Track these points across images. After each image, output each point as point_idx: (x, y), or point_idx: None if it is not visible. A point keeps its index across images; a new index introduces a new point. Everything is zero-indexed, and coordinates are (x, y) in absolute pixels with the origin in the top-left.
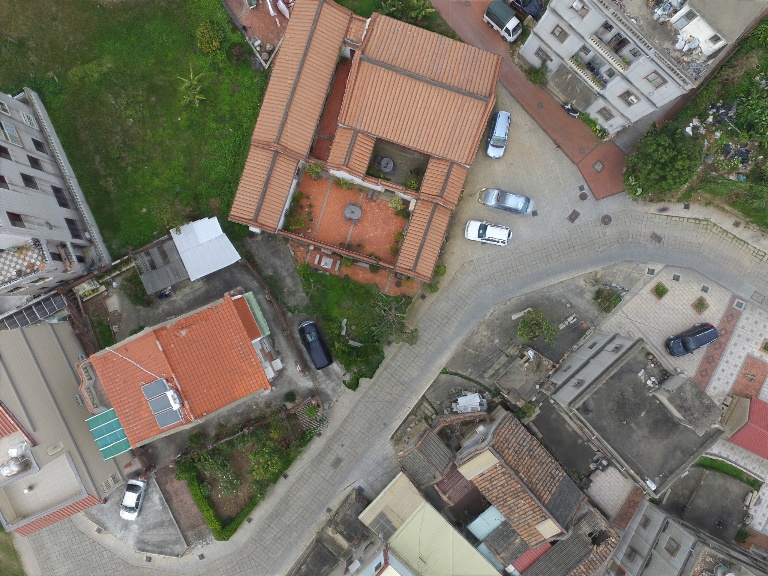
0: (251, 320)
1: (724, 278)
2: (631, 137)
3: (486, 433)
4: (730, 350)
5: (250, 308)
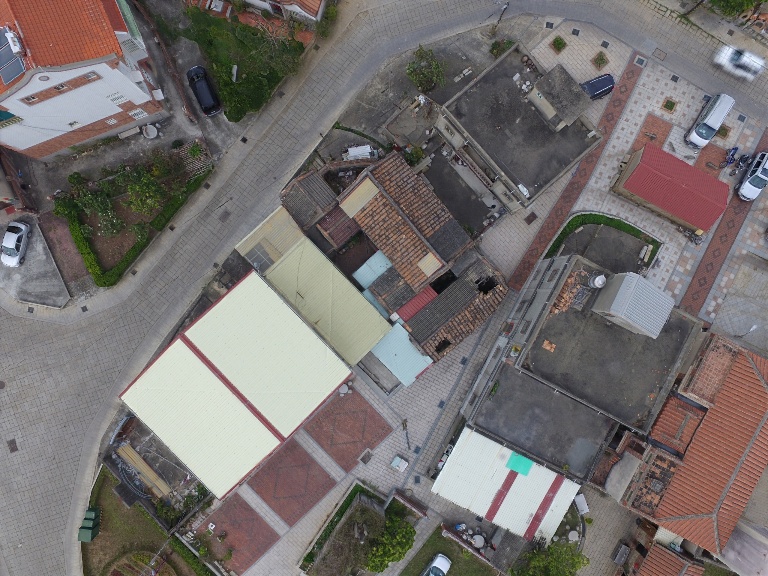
0: (117, 14)
1: (625, 34)
2: None
3: None
4: (630, 108)
5: (119, 8)
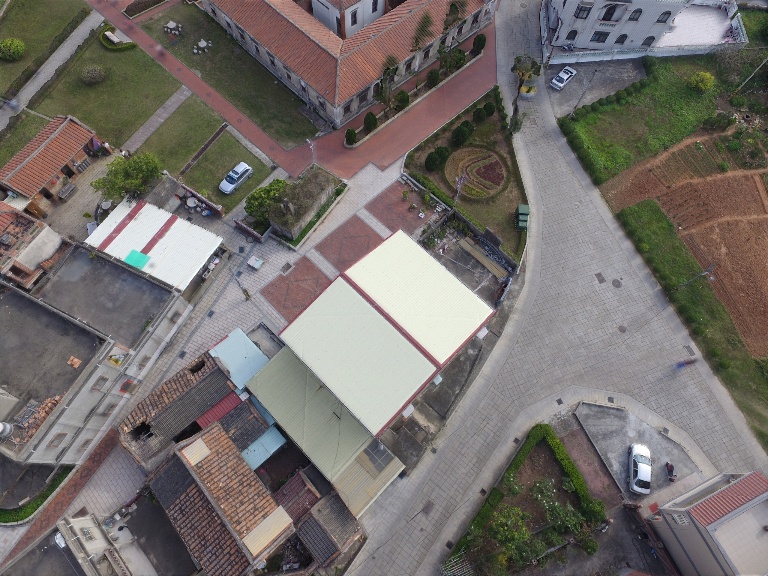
0: None
1: None
2: None
3: (255, 568)
4: None
5: None
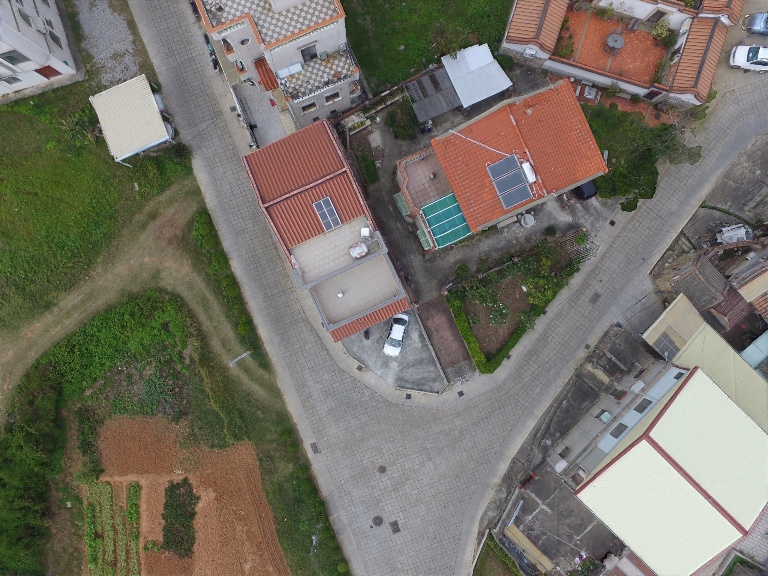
0: None
1: None
2: None
3: (765, 255)
4: None
5: None
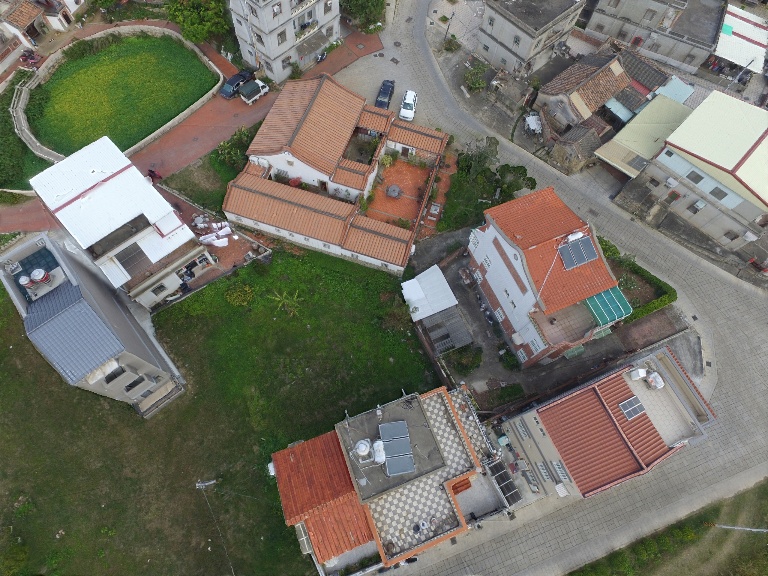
0: None
1: None
2: (341, 29)
3: (556, 104)
4: None
5: None
